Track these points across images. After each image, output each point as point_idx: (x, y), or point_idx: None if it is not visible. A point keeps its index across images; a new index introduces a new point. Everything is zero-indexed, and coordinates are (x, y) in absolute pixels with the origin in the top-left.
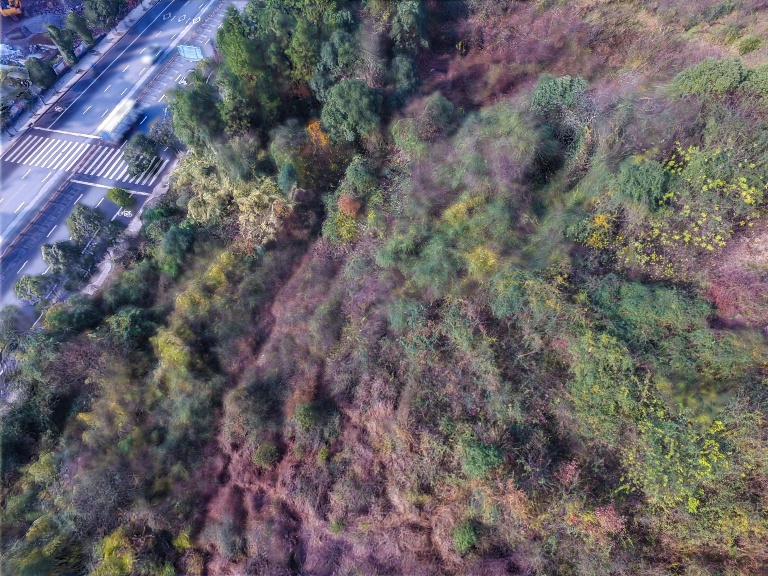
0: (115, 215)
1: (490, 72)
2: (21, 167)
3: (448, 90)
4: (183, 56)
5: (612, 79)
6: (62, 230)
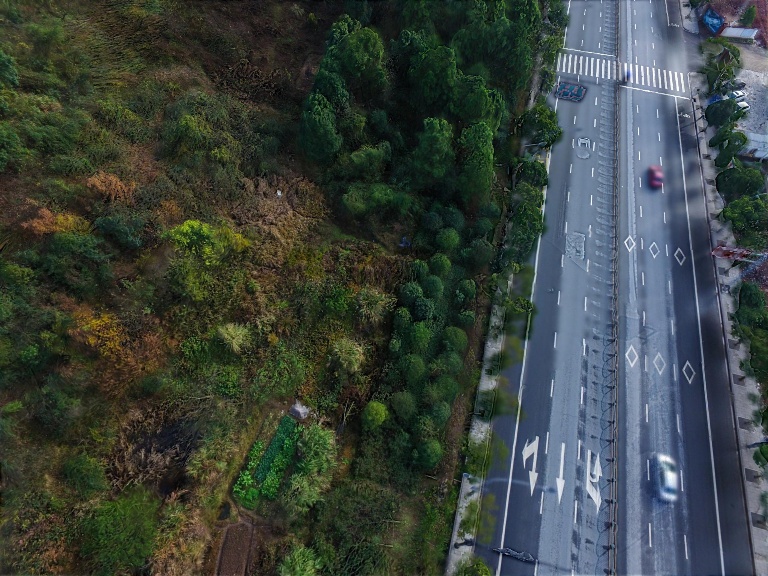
0: (566, 36)
1: (268, 52)
2: (664, 67)
3: (312, 57)
4: (579, 97)
5: (175, 2)
6: (594, 30)
